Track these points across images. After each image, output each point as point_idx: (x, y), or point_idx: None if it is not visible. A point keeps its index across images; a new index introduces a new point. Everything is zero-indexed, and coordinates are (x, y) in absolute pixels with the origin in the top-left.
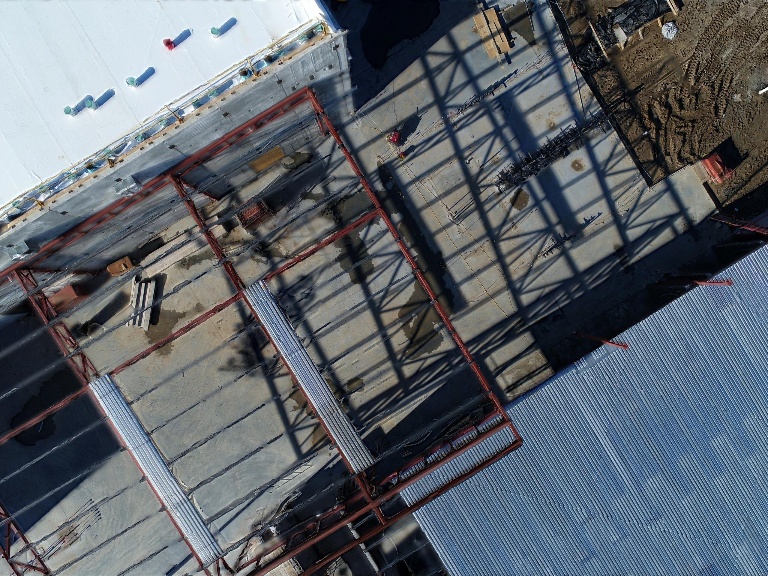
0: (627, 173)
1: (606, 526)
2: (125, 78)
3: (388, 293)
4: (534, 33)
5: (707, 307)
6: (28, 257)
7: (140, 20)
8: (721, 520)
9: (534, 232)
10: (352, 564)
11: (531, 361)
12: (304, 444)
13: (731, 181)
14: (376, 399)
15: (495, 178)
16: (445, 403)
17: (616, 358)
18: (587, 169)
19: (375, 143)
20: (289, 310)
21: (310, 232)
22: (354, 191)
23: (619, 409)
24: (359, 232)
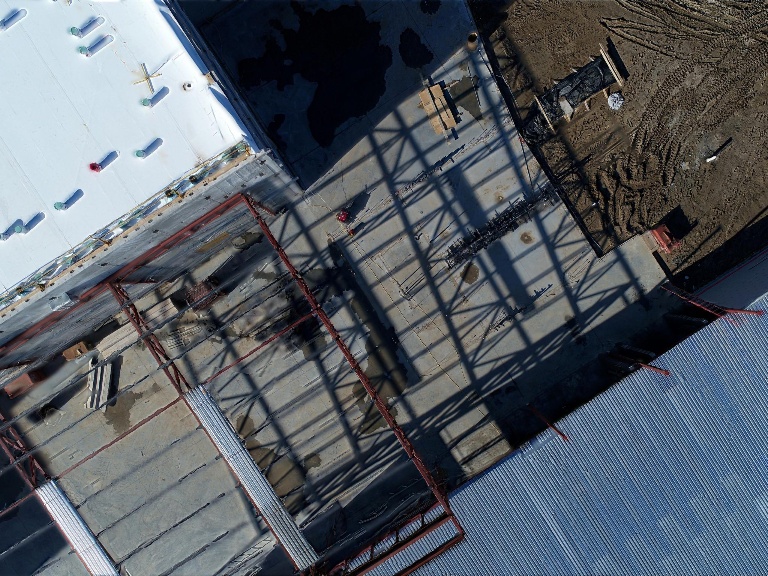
0: (576, 244)
1: None
2: (54, 201)
3: (342, 369)
4: (480, 108)
5: (651, 388)
6: None
7: (67, 143)
8: None
9: (485, 305)
10: None
11: (485, 433)
12: None
13: (681, 249)
14: (333, 474)
15: (445, 253)
16: (401, 476)
17: (561, 441)
18: (536, 241)
19: (325, 221)
20: (244, 388)
21: (263, 311)
22: (305, 269)
23: (565, 491)
24: None
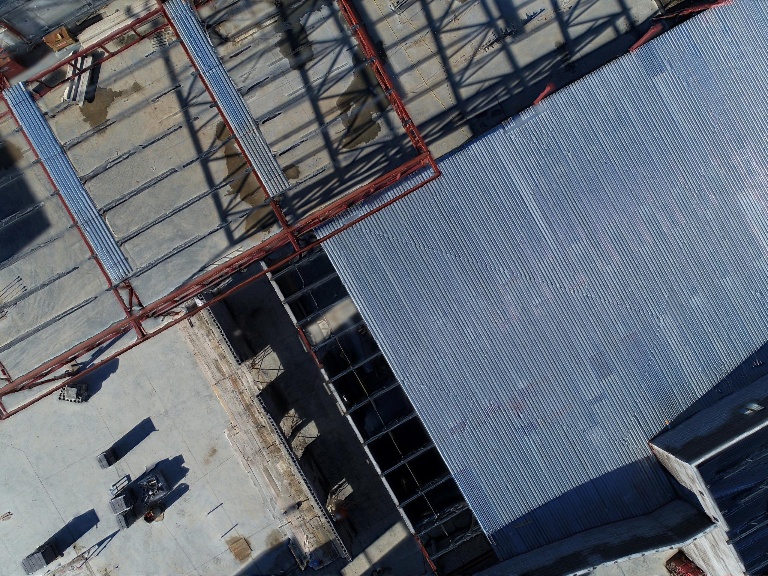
0: None
1: (528, 288)
2: None
3: (327, 80)
4: None
5: (637, 73)
6: None
7: None
8: (644, 288)
9: (476, 25)
10: (281, 353)
11: None
12: (236, 229)
13: None
14: (311, 187)
15: None
16: None
17: (544, 120)
18: None
19: None
20: None
21: (251, 16)
22: None
23: (545, 171)
24: (300, 18)
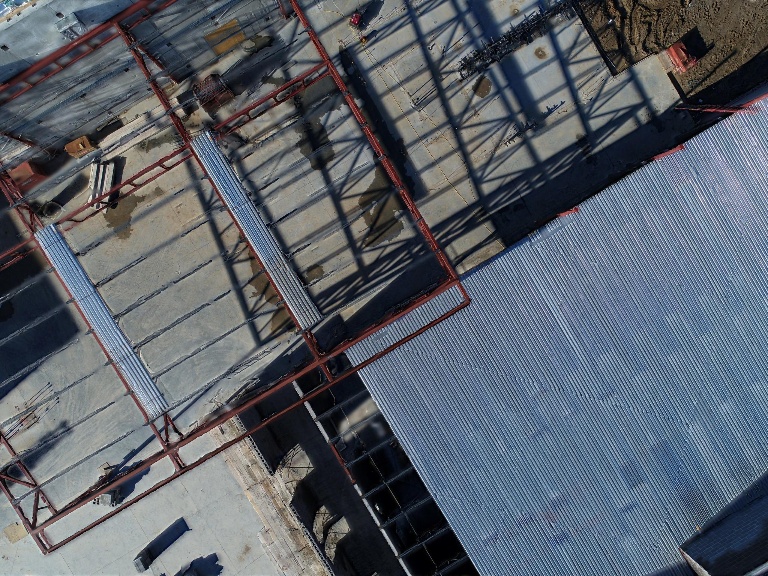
0: (591, 61)
1: (558, 399)
2: None
3: (348, 180)
4: None
5: (663, 181)
6: None
7: None
8: (673, 395)
9: (496, 120)
10: (310, 451)
11: (491, 250)
12: (263, 331)
13: (696, 72)
14: (335, 286)
15: (458, 64)
16: (404, 291)
17: (570, 231)
18: (551, 57)
19: (337, 27)
20: None
21: (270, 117)
22: (315, 76)
23: (573, 282)
24: (320, 117)
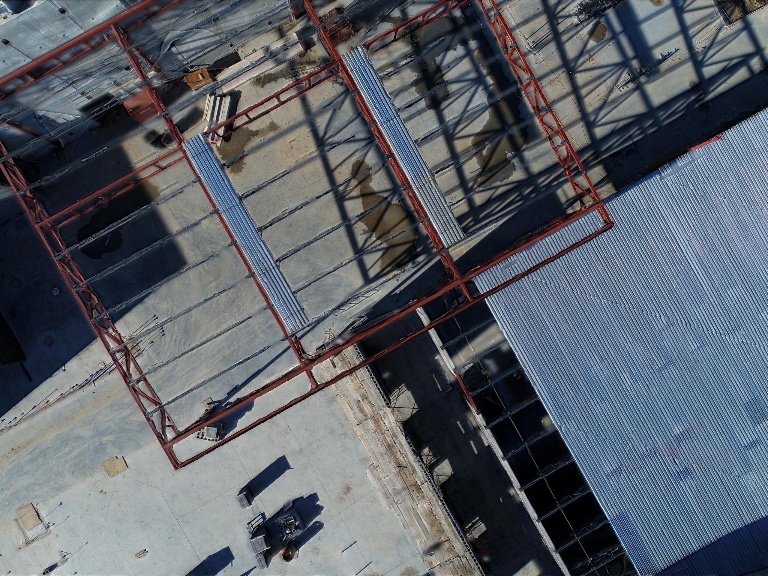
0: (705, 10)
1: (684, 334)
2: None
3: (462, 120)
4: None
5: None
6: (131, 2)
7: None
8: None
9: (610, 65)
10: (415, 392)
11: (602, 194)
12: (372, 268)
13: None
14: None
15: (574, 9)
16: (515, 233)
17: (700, 166)
18: (666, 4)
19: None
20: (362, 133)
21: (387, 55)
22: (432, 16)
23: (701, 217)
24: (436, 57)
